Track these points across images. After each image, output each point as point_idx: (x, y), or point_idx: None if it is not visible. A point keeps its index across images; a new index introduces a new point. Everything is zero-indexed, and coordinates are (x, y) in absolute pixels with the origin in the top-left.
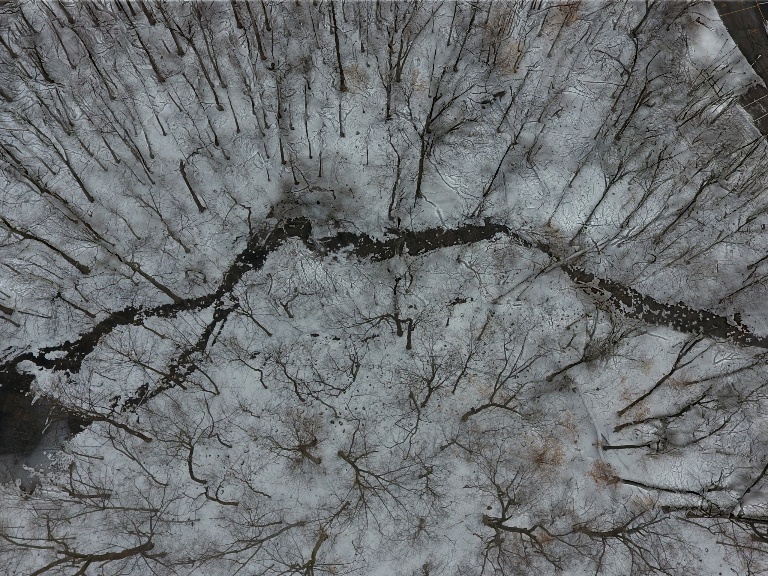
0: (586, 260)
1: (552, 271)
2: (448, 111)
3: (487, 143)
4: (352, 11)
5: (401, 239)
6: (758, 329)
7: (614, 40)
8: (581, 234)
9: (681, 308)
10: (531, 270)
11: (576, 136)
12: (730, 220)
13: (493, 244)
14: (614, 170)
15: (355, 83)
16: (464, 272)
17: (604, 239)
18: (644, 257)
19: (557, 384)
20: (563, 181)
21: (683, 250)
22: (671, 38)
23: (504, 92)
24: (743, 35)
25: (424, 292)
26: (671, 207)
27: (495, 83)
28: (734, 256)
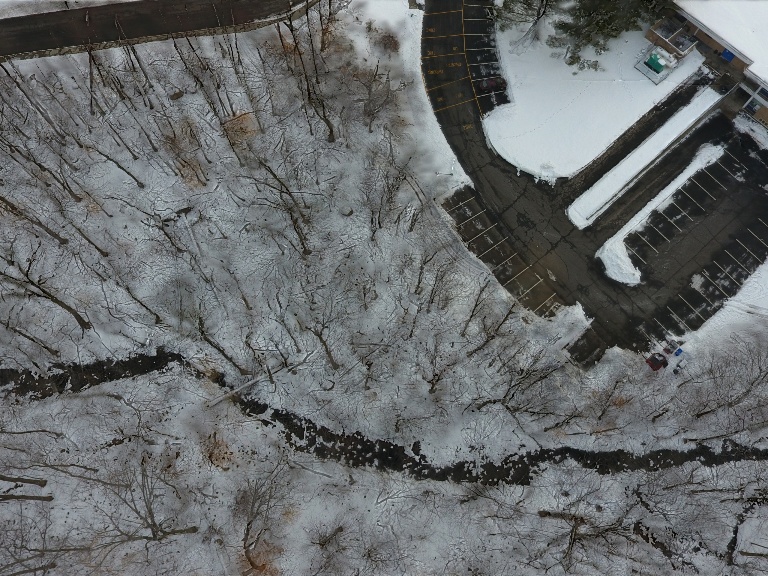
0: (260, 389)
1: (218, 405)
2: (129, 231)
3: (167, 264)
4: (34, 128)
5: (66, 374)
6: (437, 459)
7: (311, 146)
8: (255, 362)
9: (357, 438)
10: (196, 404)
11: (263, 252)
12: (417, 339)
13: (160, 376)
14: (299, 288)
15: (30, 206)
16: (123, 410)
17: (279, 366)
18: (321, 384)
19: (199, 536)
20: (240, 304)
21: (362, 375)
22: (374, 140)
23: (188, 208)
24: (457, 132)
25: (76, 435)
26: (353, 328)
27: (182, 198)
28: (418, 379)
